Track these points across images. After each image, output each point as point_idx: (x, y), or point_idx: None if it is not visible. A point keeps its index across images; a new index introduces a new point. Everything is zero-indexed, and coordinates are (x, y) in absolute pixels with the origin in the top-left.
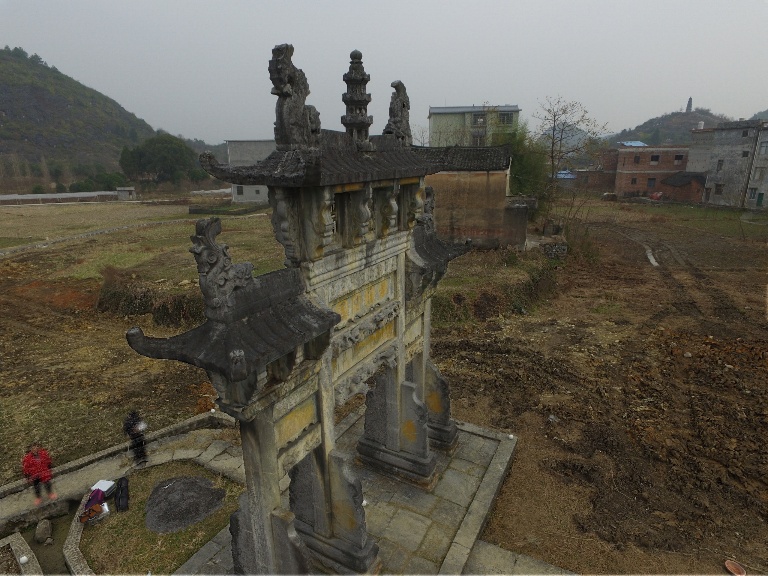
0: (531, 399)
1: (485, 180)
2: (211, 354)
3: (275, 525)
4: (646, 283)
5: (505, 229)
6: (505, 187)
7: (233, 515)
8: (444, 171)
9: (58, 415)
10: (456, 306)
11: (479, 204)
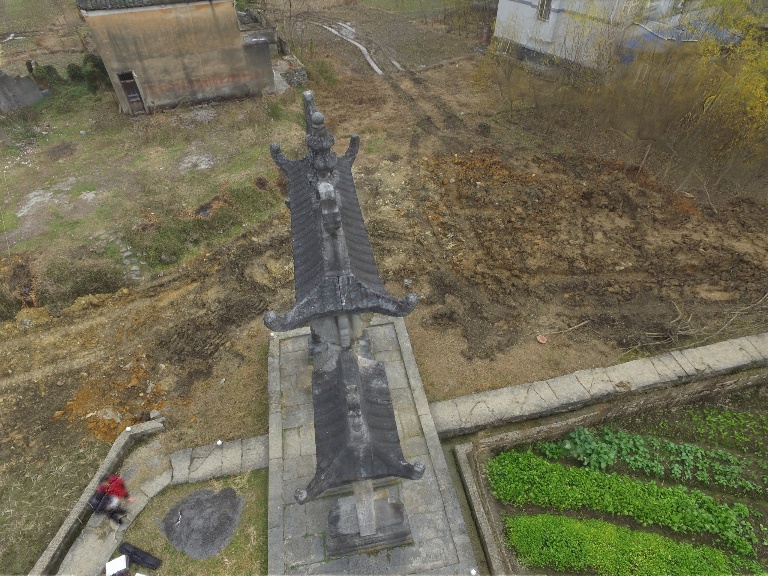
0: (380, 268)
1: (210, 13)
2: (369, 468)
3: (377, 503)
4: (386, 102)
5: (250, 71)
6: (236, 19)
7: (334, 516)
8: (153, 6)
9: None
10: (263, 192)
11: (212, 45)
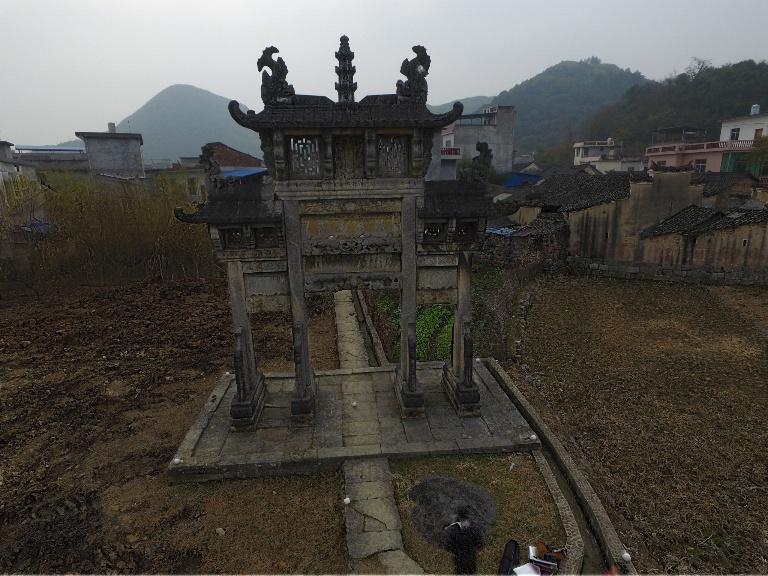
0: None
1: None
2: None
3: None
4: None
5: None
6: None
7: None
8: None
9: None
10: None
11: None
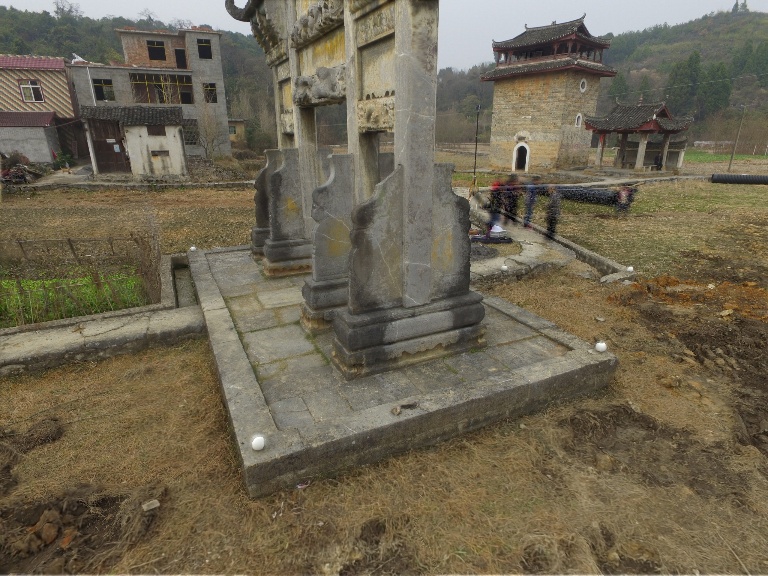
0: None
1: None
2: None
3: None
4: None
5: None
6: None
7: None
8: None
9: (670, 242)
10: None
11: None
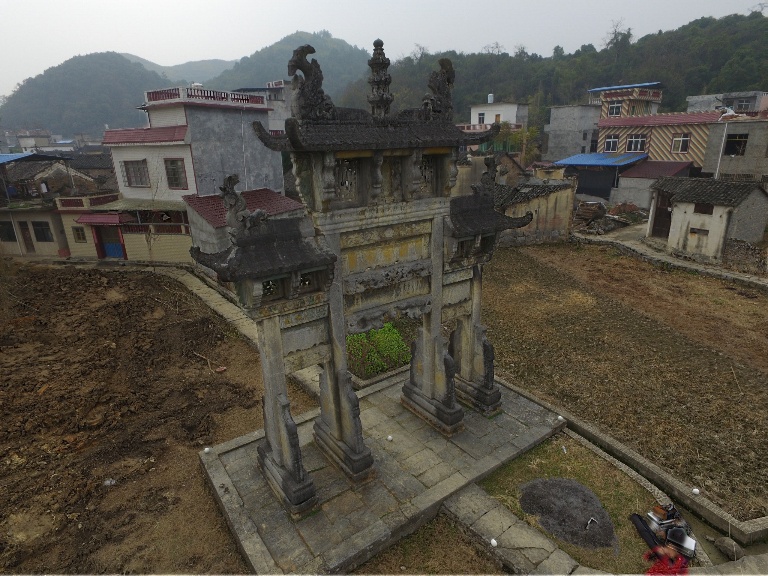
0: None
1: None
2: None
3: None
4: None
5: None
6: None
7: None
8: None
9: None
10: None
11: None
